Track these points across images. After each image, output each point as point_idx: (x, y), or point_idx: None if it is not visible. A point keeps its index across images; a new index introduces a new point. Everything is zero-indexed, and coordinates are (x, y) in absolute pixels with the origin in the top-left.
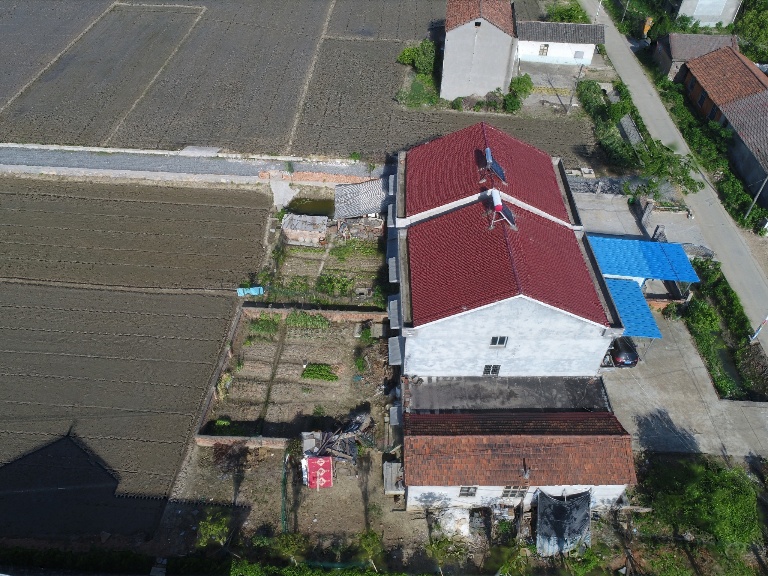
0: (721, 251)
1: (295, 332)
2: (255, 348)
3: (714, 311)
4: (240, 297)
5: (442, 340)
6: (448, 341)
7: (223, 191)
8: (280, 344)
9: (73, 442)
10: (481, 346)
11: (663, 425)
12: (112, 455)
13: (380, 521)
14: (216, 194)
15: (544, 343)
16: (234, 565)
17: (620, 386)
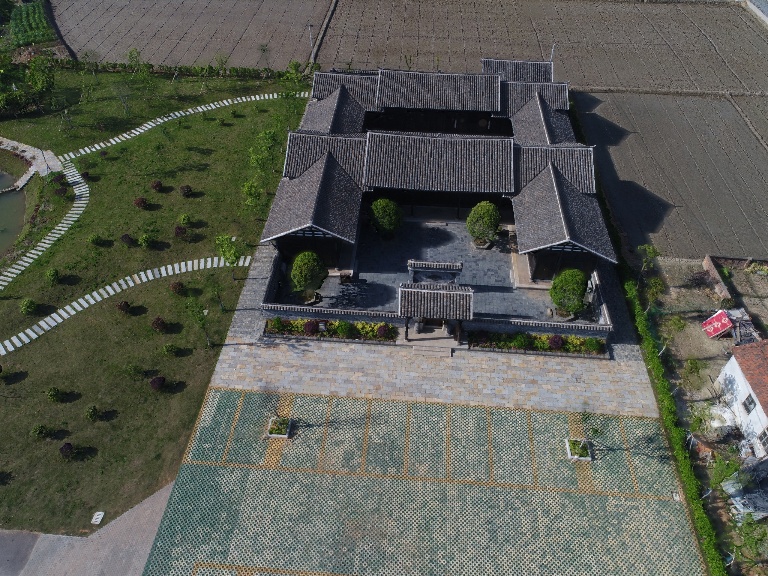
0: None
1: None
2: None
3: None
4: None
5: None
6: None
7: None
8: None
9: (673, 209)
10: None
11: None
12: (673, 227)
13: None
14: None
15: None
16: (632, 283)
17: None
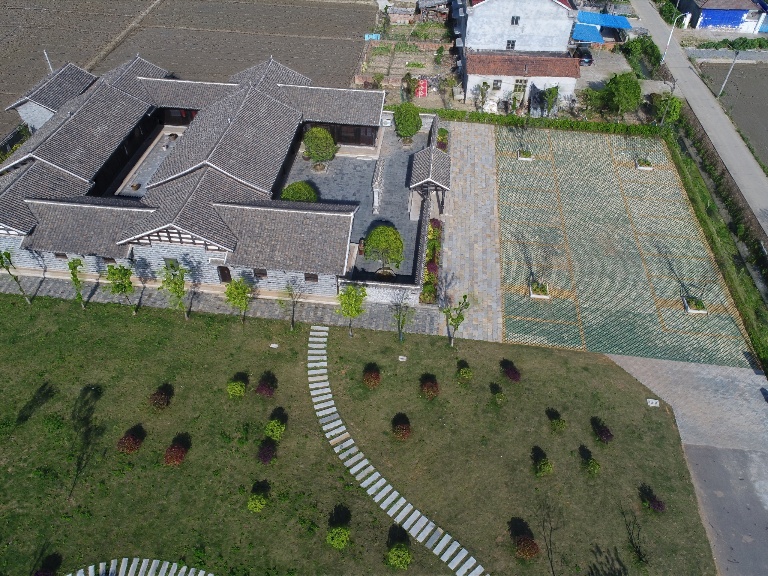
0: (654, 33)
1: (400, 52)
2: (378, 57)
3: (645, 59)
4: (366, 41)
5: (486, 18)
6: (489, 19)
7: (346, 4)
8: (392, 57)
9: None
10: (506, 24)
11: (602, 84)
12: None
13: (452, 106)
14: (342, 5)
15: (538, 22)
16: (384, 106)
17: (581, 72)
